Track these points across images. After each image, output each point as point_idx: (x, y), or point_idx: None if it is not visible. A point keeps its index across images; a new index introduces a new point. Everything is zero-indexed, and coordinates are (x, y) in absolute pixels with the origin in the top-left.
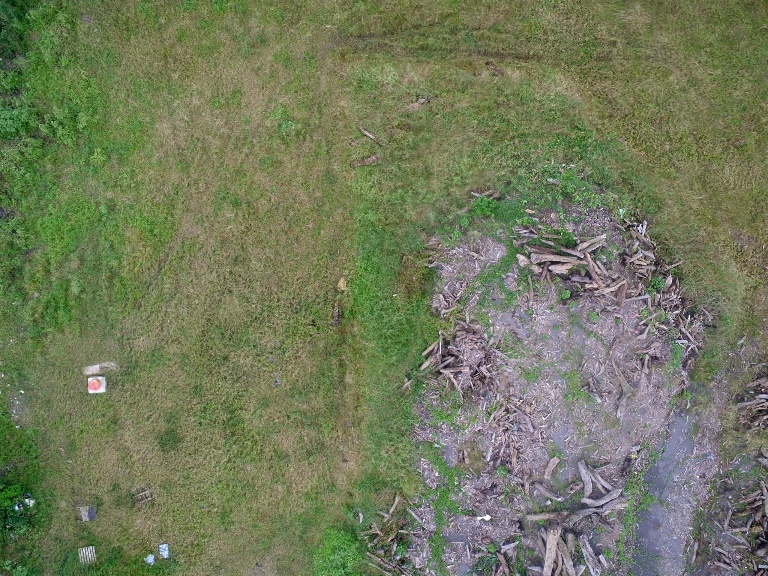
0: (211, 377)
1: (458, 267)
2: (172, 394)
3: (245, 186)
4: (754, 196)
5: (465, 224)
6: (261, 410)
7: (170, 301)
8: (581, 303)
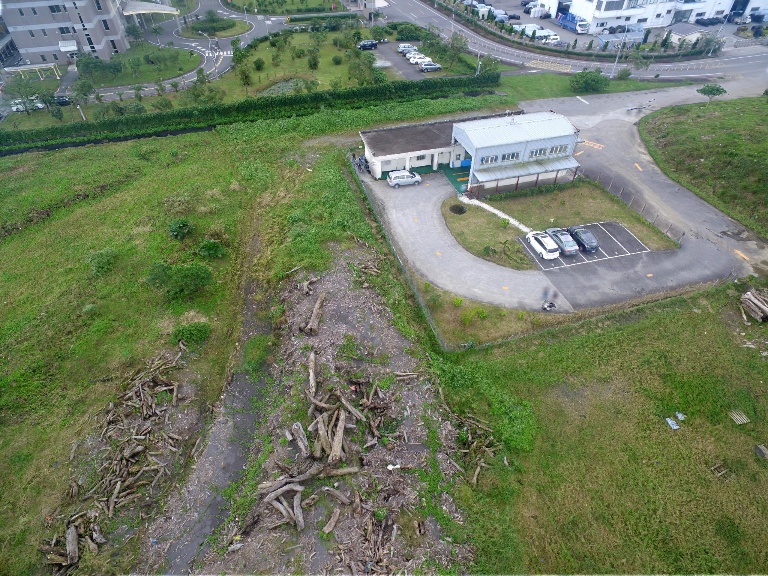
0: None
1: None
2: None
3: None
4: None
5: None
6: (647, 573)
7: None
8: None
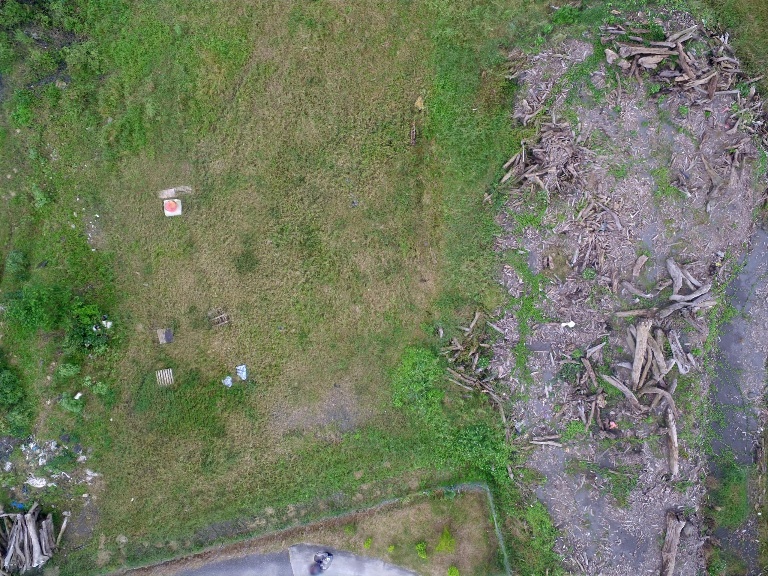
0: (287, 199)
1: (543, 69)
2: (248, 216)
3: (320, 7)
4: None
5: (548, 30)
6: (338, 231)
7: (245, 124)
8: (670, 99)
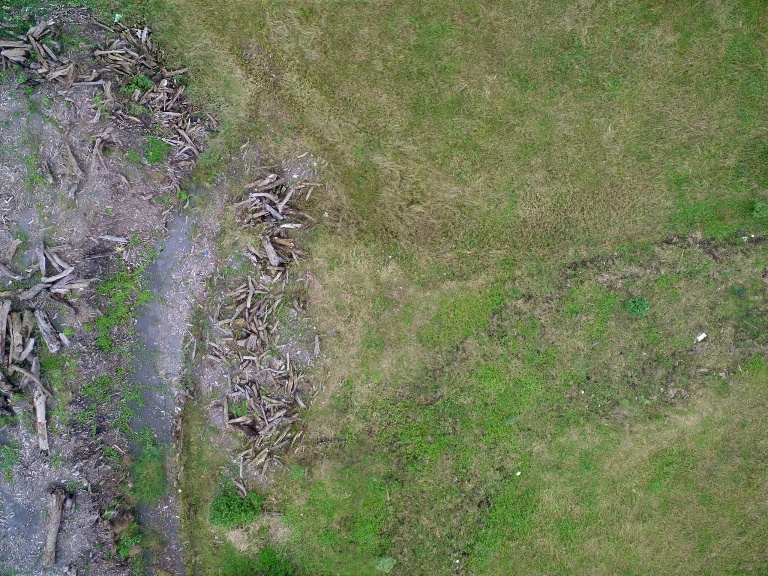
0: None
1: None
2: None
3: None
4: (263, 7)
5: None
6: None
7: None
8: (40, 90)
